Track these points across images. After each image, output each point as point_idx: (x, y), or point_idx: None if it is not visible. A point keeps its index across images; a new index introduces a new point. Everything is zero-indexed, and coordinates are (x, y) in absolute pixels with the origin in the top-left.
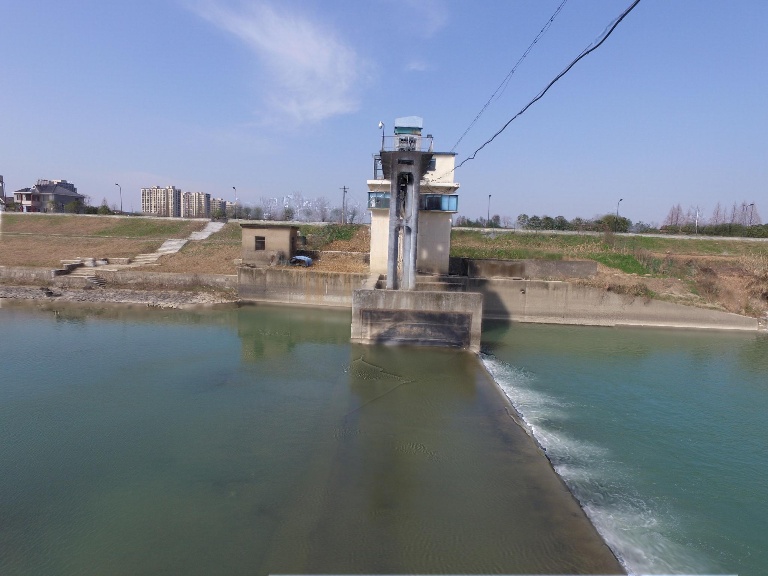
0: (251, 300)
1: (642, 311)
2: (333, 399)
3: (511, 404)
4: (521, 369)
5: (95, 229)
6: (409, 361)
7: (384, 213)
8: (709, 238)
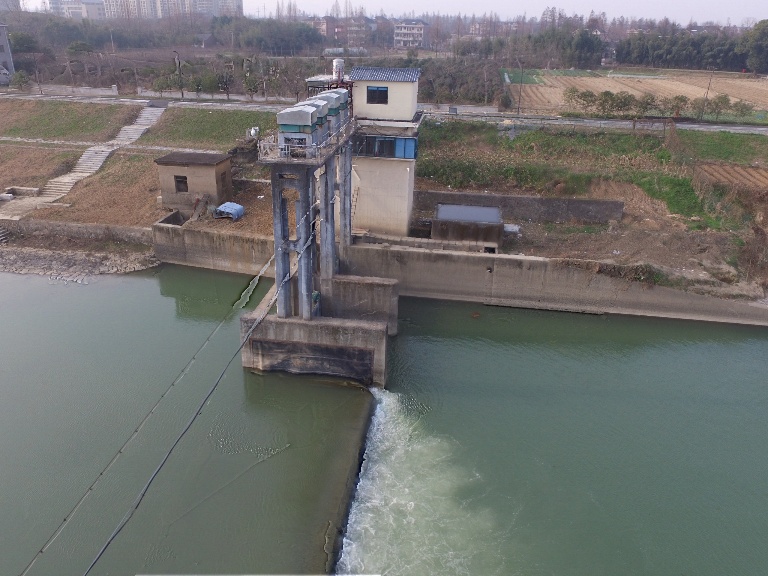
0: (171, 262)
1: (640, 299)
2: (173, 492)
3: (348, 507)
4: (413, 425)
5: (5, 123)
6: (305, 395)
7: None
8: None
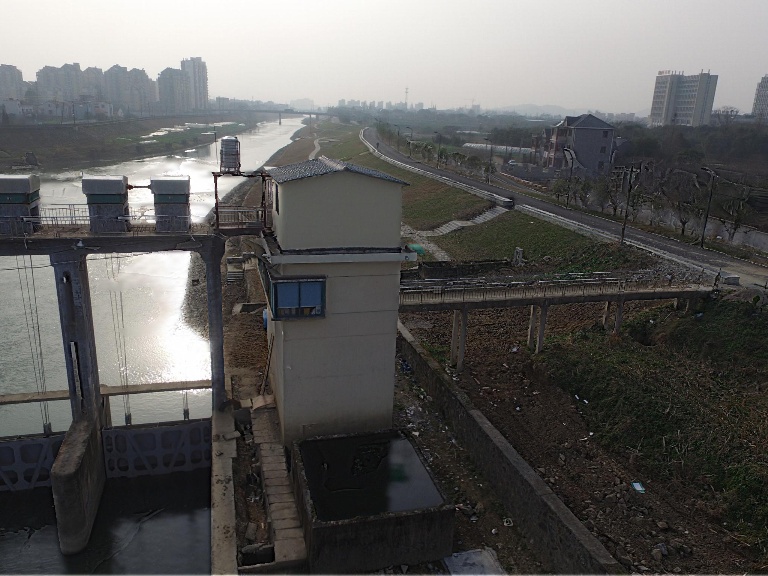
0: None
1: None
2: None
3: None
4: None
5: (407, 201)
6: None
7: None
8: None
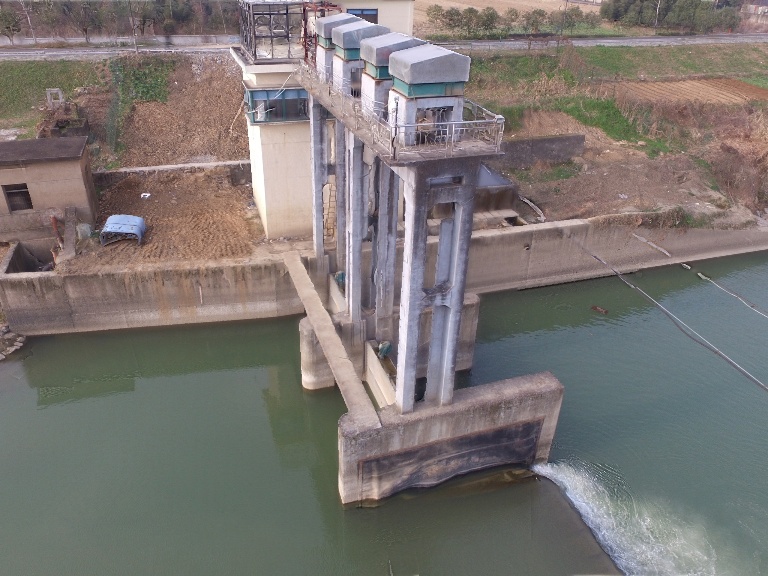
0: (44, 334)
1: (674, 246)
2: None
3: None
4: (635, 510)
5: None
6: (446, 512)
7: (285, 128)
8: (681, 42)
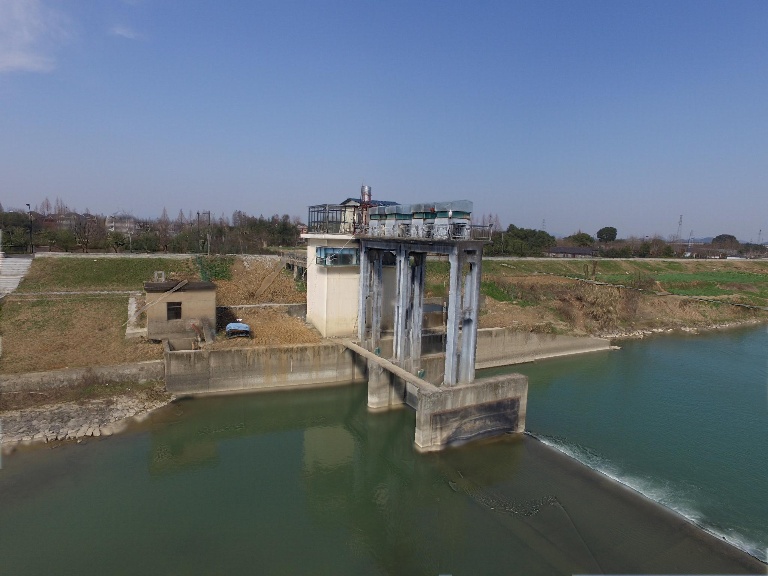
0: (188, 393)
1: (550, 345)
2: (561, 566)
3: None
4: (579, 446)
5: None
6: (476, 458)
7: (340, 270)
8: (519, 259)
